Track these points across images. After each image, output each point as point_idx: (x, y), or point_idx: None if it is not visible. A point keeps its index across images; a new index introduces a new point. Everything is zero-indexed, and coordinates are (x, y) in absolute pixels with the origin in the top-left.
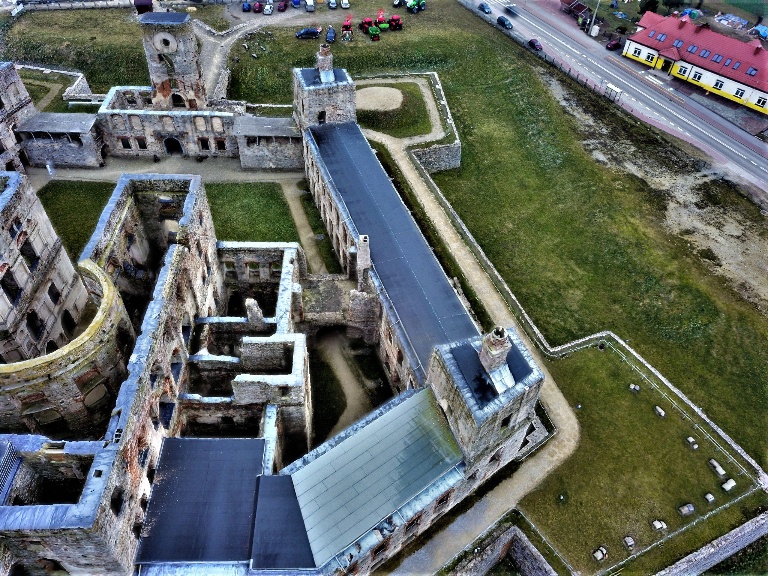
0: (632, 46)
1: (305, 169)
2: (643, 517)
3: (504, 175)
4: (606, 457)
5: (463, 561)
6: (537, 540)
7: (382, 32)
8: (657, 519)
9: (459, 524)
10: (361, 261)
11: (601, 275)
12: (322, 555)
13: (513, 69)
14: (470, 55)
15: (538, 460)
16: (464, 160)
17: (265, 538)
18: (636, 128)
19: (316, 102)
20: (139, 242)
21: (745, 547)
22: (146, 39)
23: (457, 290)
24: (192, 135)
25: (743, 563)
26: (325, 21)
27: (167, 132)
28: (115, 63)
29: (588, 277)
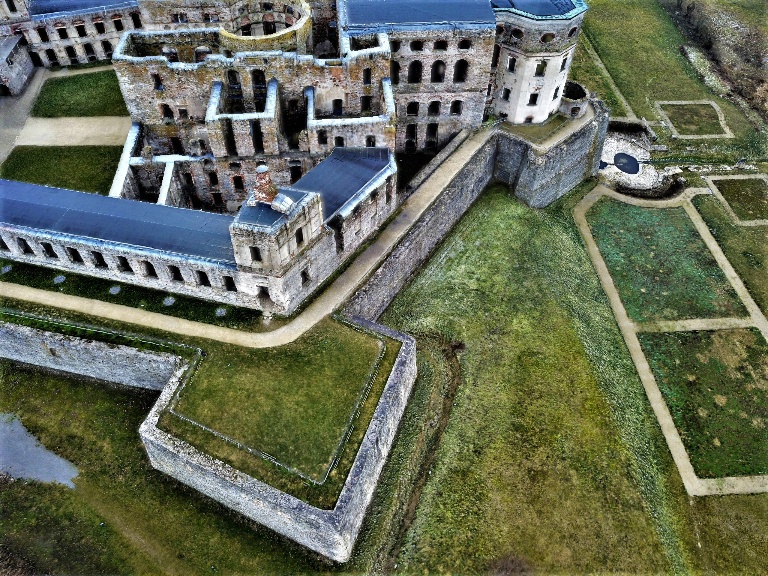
0: None
1: (42, 59)
2: None
3: None
4: None
5: None
6: None
7: None
8: None
9: None
10: None
11: None
12: None
13: None
14: None
15: None
16: None
17: None
18: None
19: None
20: None
21: None
22: None
23: None
24: None
25: None
26: None
27: None
28: None
29: None
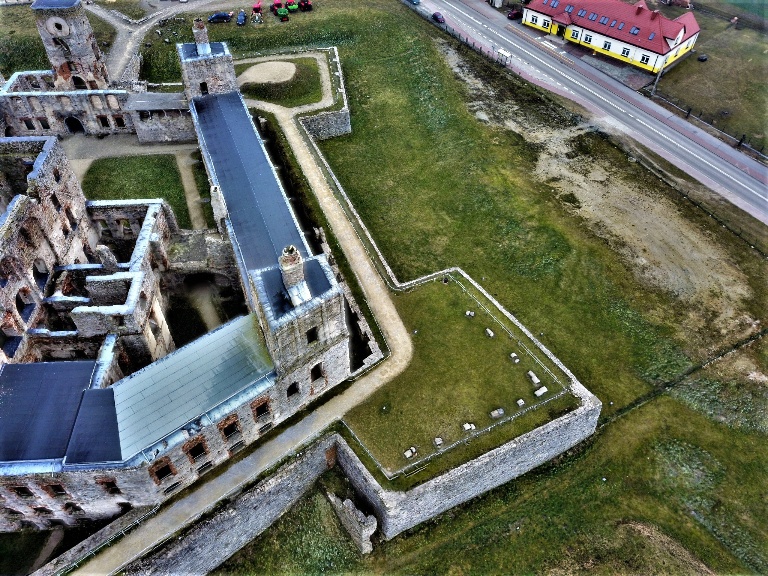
0: (529, 14)
1: None
2: (456, 421)
3: (392, 138)
4: (432, 373)
5: (285, 464)
6: (356, 444)
7: (292, 13)
8: (468, 422)
9: (287, 434)
10: (216, 211)
11: (468, 222)
12: (129, 450)
13: (414, 41)
14: (375, 30)
15: (370, 379)
16: (356, 126)
17: (81, 439)
18: (522, 89)
19: (195, 74)
20: (5, 201)
21: (566, 450)
22: (39, 24)
23: (321, 238)
24: (90, 113)
25: (563, 464)
26: (239, 6)
27: (66, 112)
28: (33, 54)
29: (456, 225)
